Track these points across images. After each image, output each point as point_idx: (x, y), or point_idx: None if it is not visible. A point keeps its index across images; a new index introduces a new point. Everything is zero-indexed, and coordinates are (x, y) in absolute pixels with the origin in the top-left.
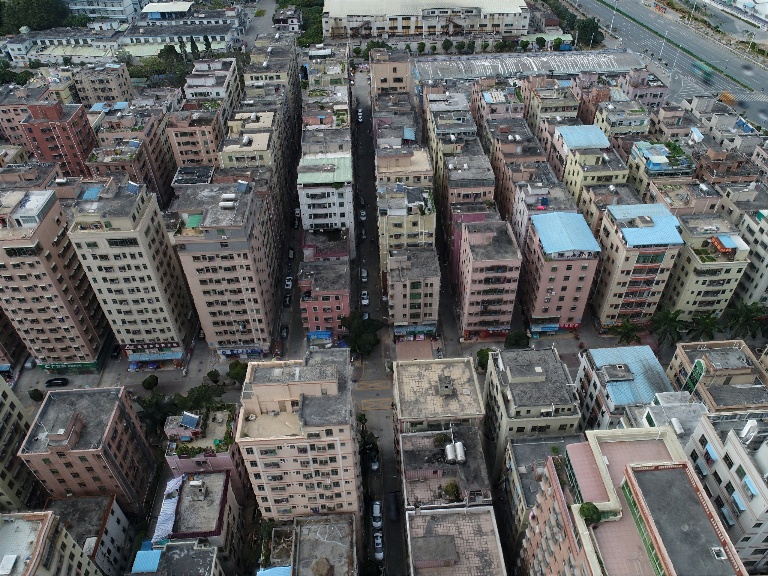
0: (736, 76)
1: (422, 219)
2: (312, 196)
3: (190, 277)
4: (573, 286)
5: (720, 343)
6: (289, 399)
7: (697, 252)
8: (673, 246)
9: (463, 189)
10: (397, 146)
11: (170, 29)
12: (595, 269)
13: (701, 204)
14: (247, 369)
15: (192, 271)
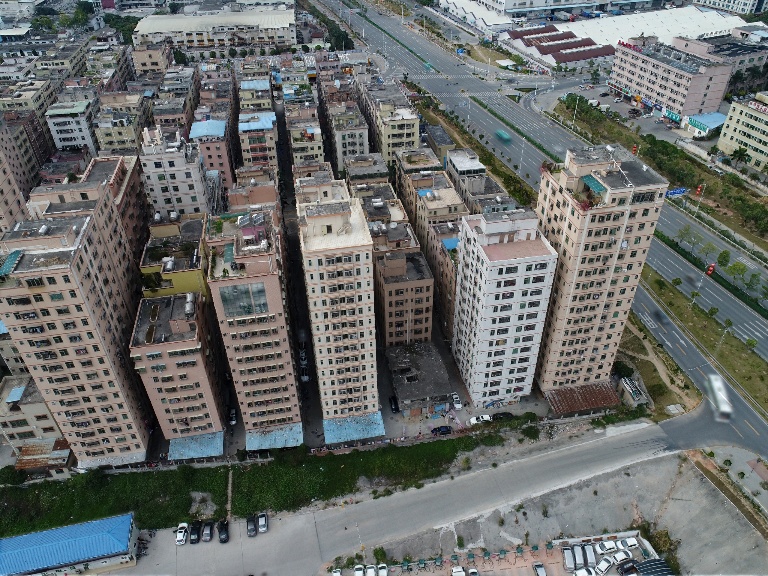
0: (436, 65)
1: (124, 130)
2: (57, 124)
3: None
4: (217, 163)
5: (263, 168)
6: None
7: (295, 139)
8: (268, 131)
9: (163, 116)
10: None
11: (8, 47)
12: (226, 149)
13: (305, 114)
14: None
15: None
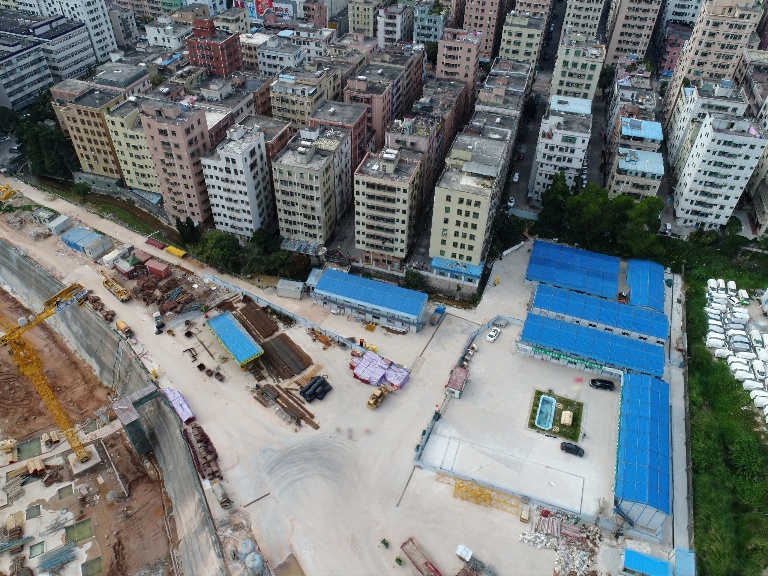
0: None
1: None
2: None
3: (621, 13)
4: None
5: None
6: (730, 6)
7: None
8: None
9: None
10: None
11: None
12: None
13: None
14: (703, 3)
15: (625, 9)
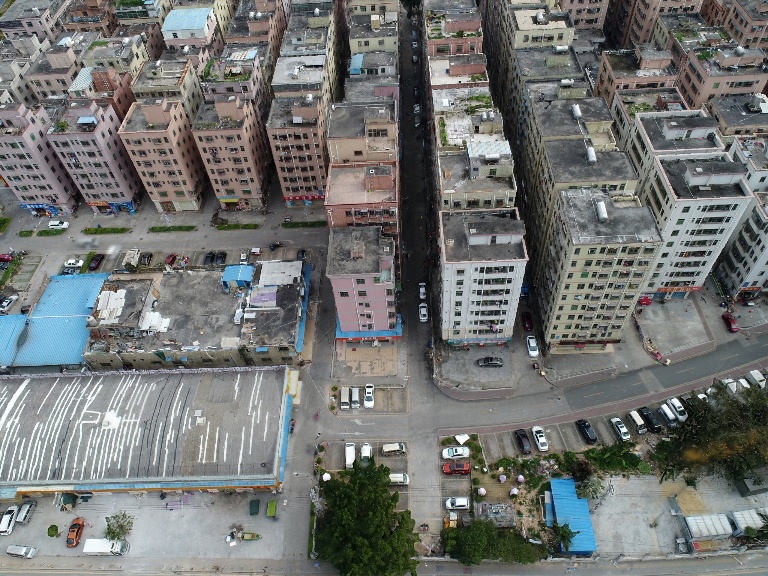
0: None
1: None
2: None
3: None
4: None
5: None
6: None
7: None
8: None
9: None
10: (375, 19)
11: None
12: None
13: None
14: None
15: None
